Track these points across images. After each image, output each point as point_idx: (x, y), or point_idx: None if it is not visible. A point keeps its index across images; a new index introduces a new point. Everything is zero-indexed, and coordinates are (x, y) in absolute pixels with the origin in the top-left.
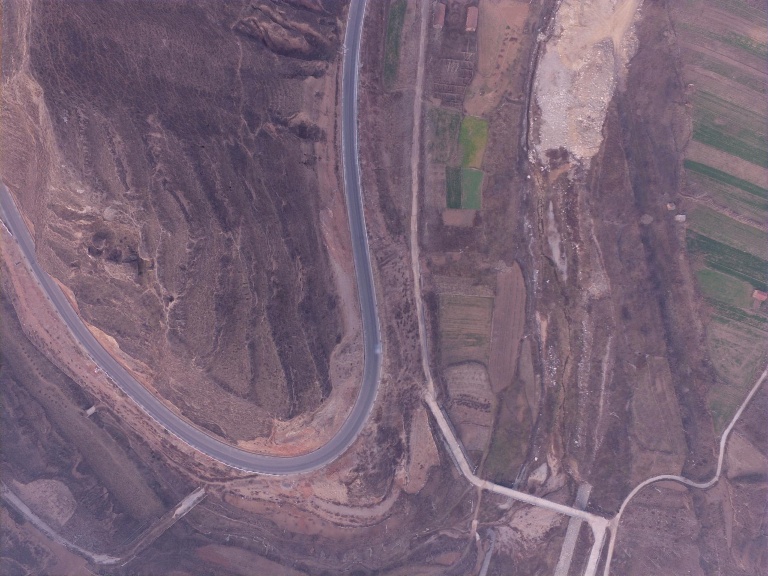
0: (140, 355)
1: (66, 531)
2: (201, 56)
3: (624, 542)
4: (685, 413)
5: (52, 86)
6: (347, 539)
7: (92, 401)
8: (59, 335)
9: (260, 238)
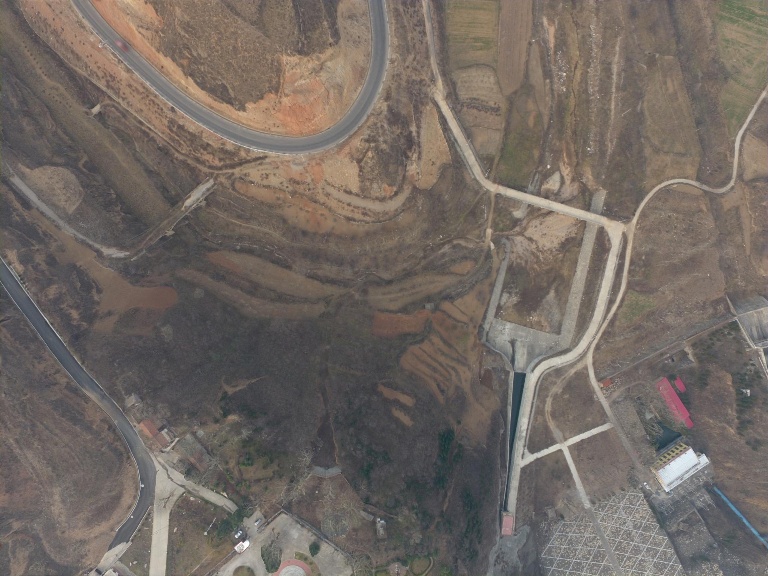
0: None
1: (74, 220)
2: None
3: (641, 248)
4: (698, 111)
5: None
6: (360, 236)
7: (97, 101)
8: (62, 10)
9: None
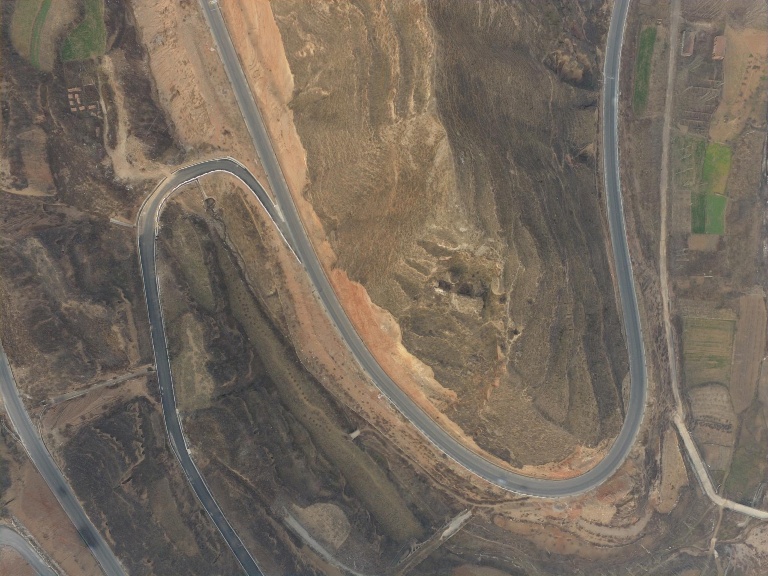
0: (455, 384)
1: (340, 554)
2: (530, 91)
3: None
4: None
5: (452, 128)
6: (602, 559)
7: (355, 425)
8: (344, 362)
9: (579, 269)
